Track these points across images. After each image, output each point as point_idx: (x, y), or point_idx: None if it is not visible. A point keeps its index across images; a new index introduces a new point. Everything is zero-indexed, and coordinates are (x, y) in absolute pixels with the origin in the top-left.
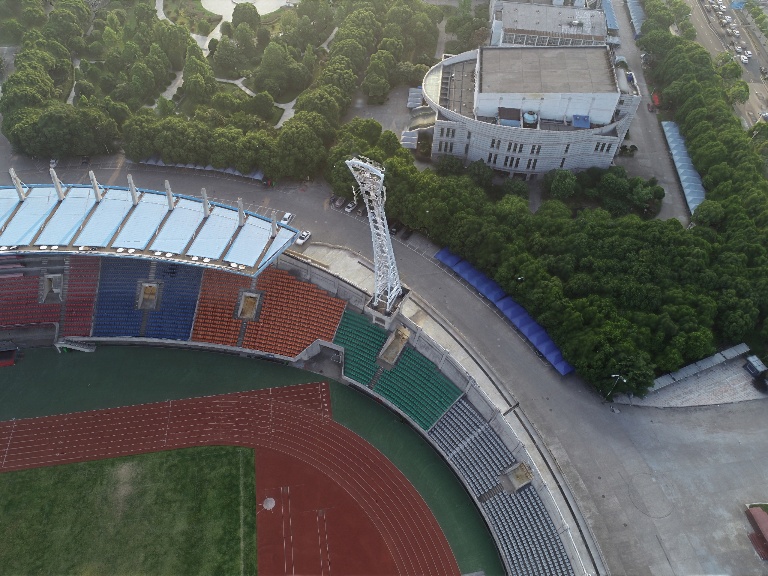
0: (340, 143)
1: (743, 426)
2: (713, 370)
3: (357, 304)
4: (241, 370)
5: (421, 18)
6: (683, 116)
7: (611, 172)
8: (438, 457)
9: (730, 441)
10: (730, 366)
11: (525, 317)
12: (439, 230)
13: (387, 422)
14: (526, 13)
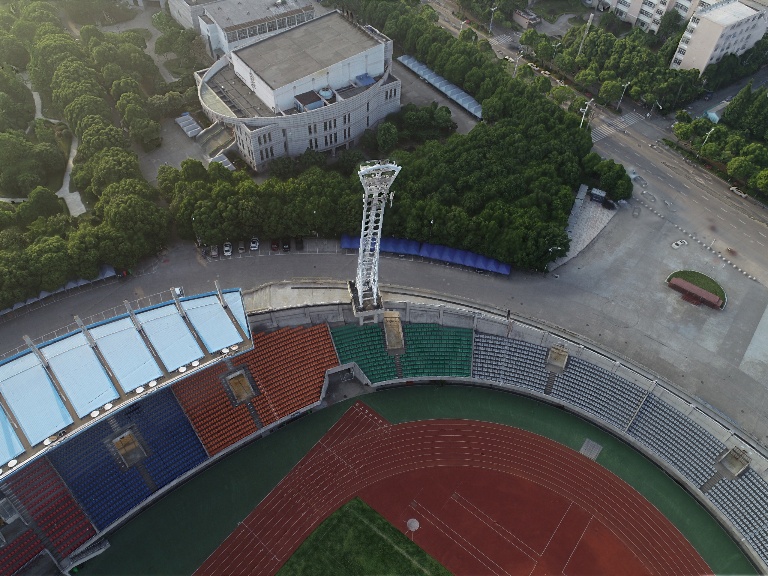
0: (179, 195)
1: (622, 237)
2: (579, 213)
3: (336, 319)
4: (277, 447)
5: (130, 49)
6: (413, 47)
7: (408, 111)
8: (489, 390)
9: (625, 250)
10: (584, 204)
11: (449, 251)
12: (333, 223)
13: (432, 394)
14: (231, 8)
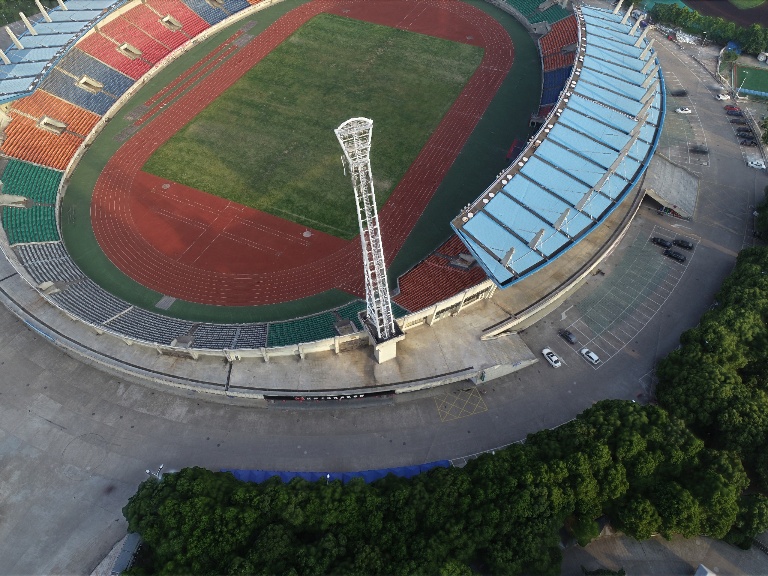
0: None
1: None
2: None
3: None
4: (419, 257)
5: None
6: None
7: None
8: None
9: None
10: None
11: None
12: (468, 464)
13: None
14: None
